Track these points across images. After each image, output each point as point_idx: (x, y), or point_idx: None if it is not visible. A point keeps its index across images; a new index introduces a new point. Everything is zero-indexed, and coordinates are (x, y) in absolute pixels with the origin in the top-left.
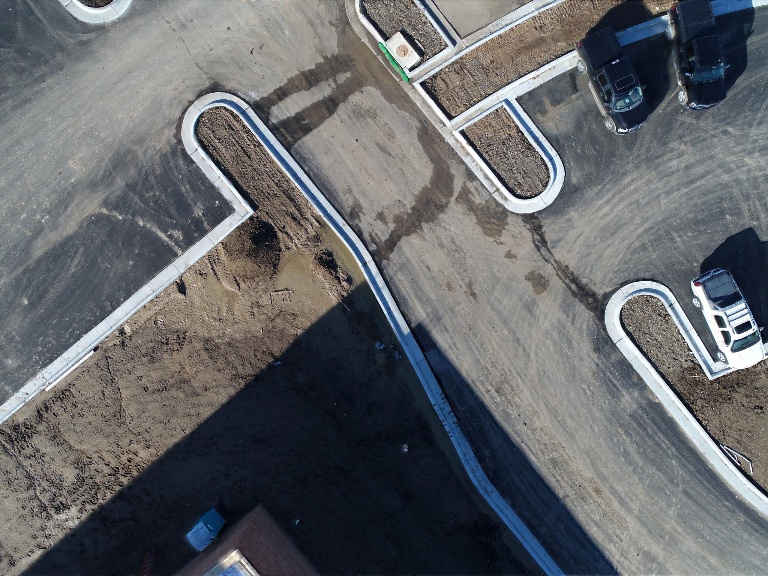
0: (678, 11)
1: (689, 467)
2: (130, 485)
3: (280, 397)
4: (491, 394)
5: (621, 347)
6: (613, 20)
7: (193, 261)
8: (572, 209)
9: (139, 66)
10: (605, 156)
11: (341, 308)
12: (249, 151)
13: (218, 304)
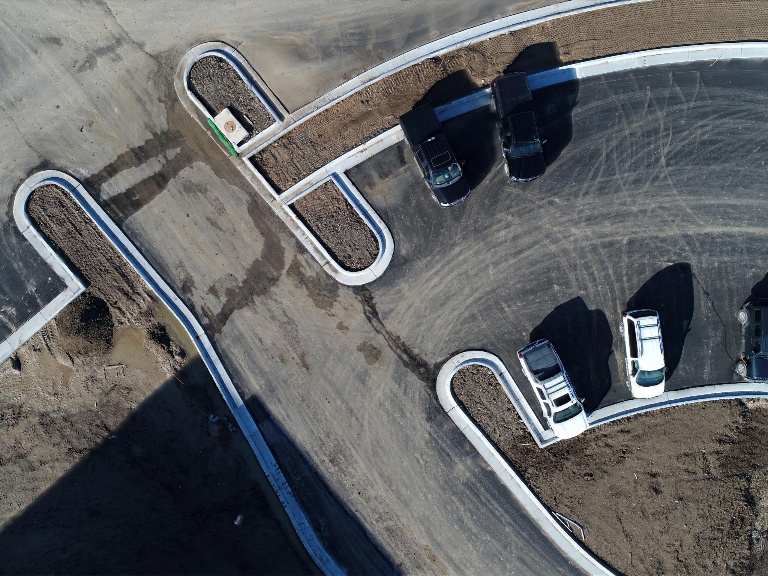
0: (496, 87)
1: (522, 534)
2: None
3: (115, 470)
4: (325, 464)
5: (453, 416)
6: (439, 93)
7: (27, 337)
8: (402, 280)
9: None
10: (434, 228)
11: (174, 381)
12: (80, 228)
13: (53, 379)
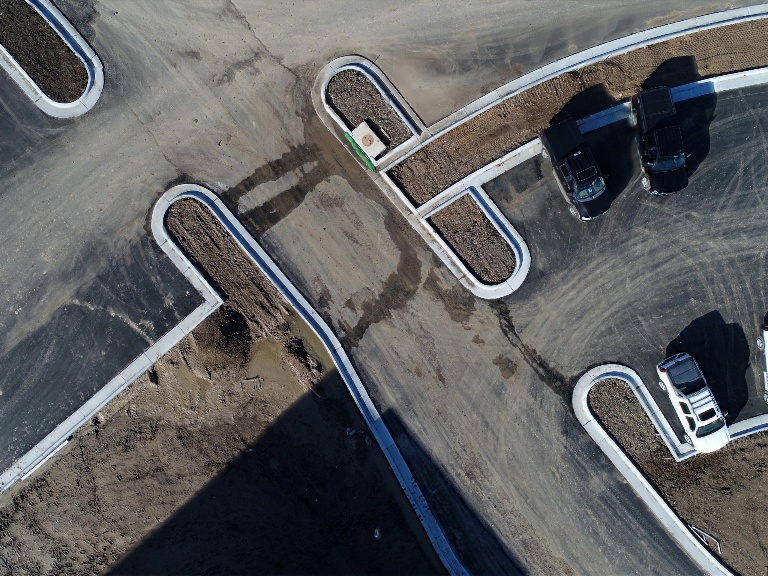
0: (639, 101)
1: (658, 547)
2: (105, 573)
3: (252, 484)
4: (461, 477)
5: (589, 429)
6: (577, 107)
7: (164, 351)
8: (538, 294)
9: (109, 159)
10: (570, 241)
11: (311, 395)
12: (218, 241)
13: (190, 392)
